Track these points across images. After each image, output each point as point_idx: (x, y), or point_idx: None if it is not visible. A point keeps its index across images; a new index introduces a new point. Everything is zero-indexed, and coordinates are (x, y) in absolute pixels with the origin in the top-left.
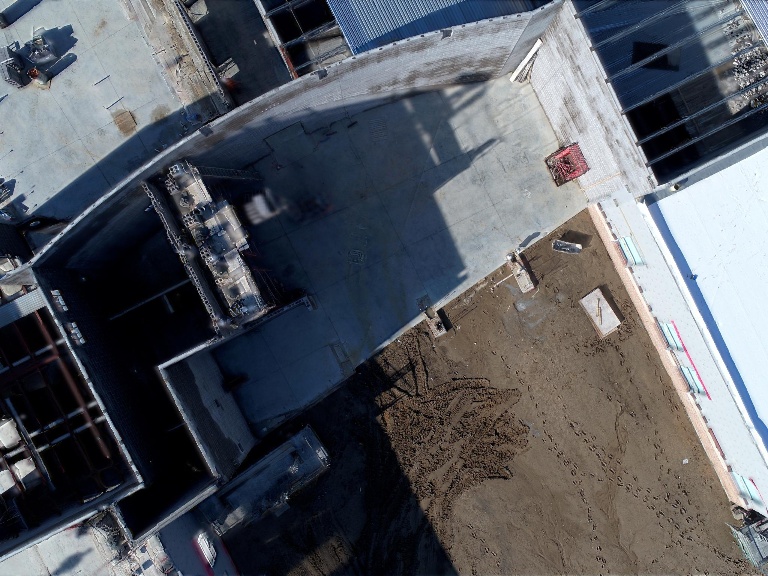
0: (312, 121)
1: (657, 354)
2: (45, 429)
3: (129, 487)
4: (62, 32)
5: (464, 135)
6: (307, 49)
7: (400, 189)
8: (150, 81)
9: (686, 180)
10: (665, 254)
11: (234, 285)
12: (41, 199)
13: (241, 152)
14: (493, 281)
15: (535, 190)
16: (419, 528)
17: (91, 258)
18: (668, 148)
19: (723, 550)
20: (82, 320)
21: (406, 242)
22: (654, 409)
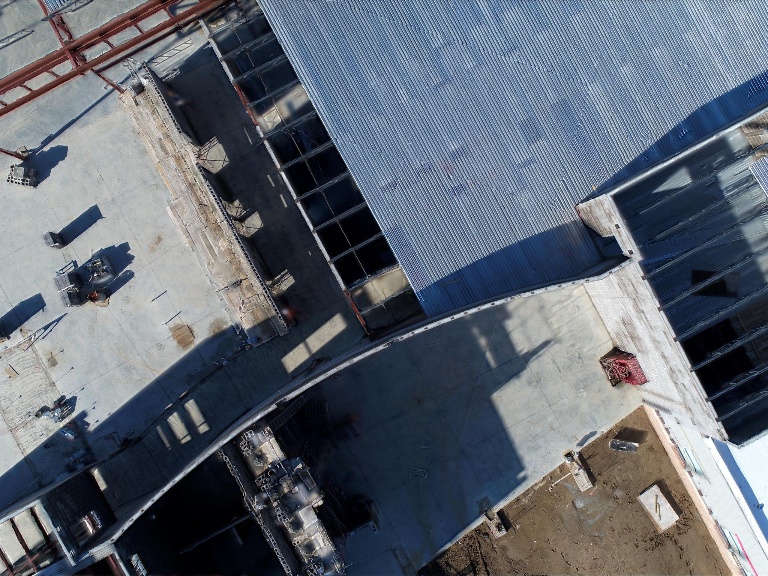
0: None
1: (716, 547)
2: None
3: None
4: (119, 250)
5: (519, 338)
6: None
7: (457, 393)
8: (207, 295)
9: None
10: (732, 486)
11: (309, 541)
12: (102, 415)
13: None
14: (551, 480)
15: (590, 390)
16: None
17: None
18: (737, 403)
19: None
20: (159, 575)
21: (464, 445)
22: None
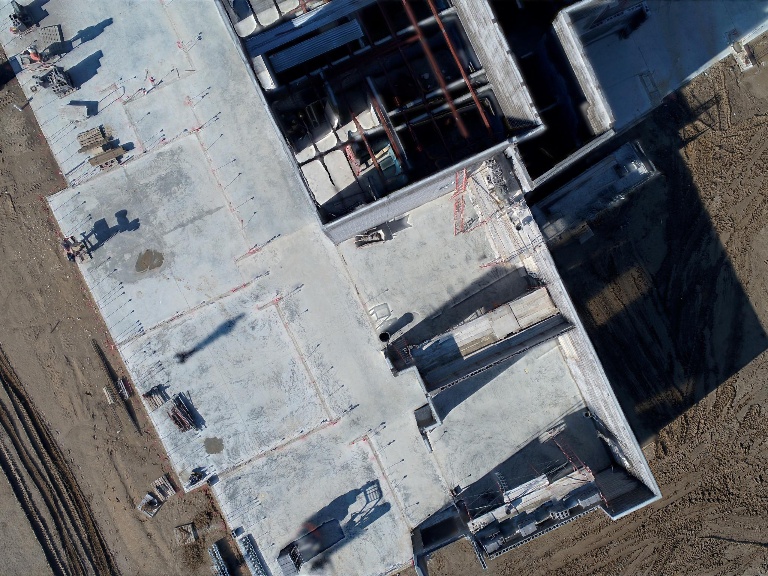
0: None
1: None
2: (403, 108)
3: None
4: None
5: None
6: None
7: None
8: None
9: None
10: None
11: None
12: None
13: None
14: None
15: None
16: (718, 261)
17: None
18: None
19: None
20: None
21: None
22: None
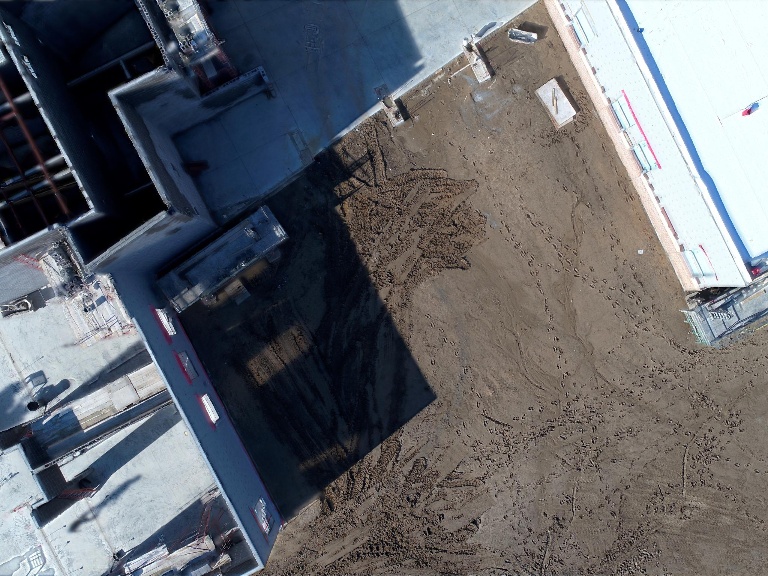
0: None
1: (612, 145)
2: (2, 185)
3: None
4: None
5: None
6: None
7: None
8: None
9: None
10: (611, 5)
11: (185, 24)
12: None
13: None
14: (450, 72)
15: None
16: (378, 317)
17: (47, 20)
18: None
19: (678, 341)
20: (36, 64)
21: (364, 31)
22: (610, 200)
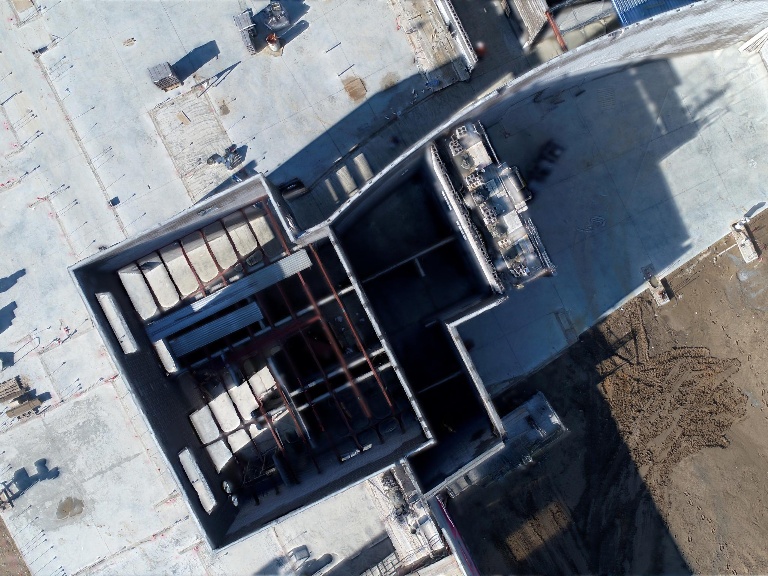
0: (553, 88)
1: None
2: (305, 388)
3: (415, 443)
4: None
5: (691, 104)
6: (560, 15)
7: (627, 158)
8: (381, 49)
9: None
10: None
11: (512, 246)
12: (272, 165)
13: (489, 118)
14: (716, 251)
15: (761, 160)
16: (637, 495)
17: (347, 221)
18: None
19: None
20: None
21: (631, 211)
22: None
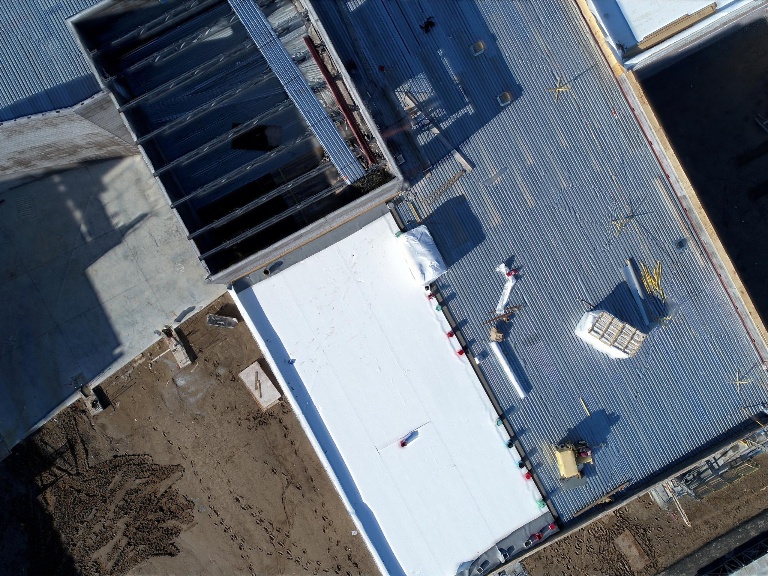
0: None
1: None
2: None
3: None
4: None
5: (115, 210)
6: None
7: (51, 267)
8: None
9: (280, 264)
10: (258, 340)
11: None
12: None
13: None
14: (151, 356)
15: (189, 264)
16: None
17: None
18: (221, 241)
19: None
20: None
21: (59, 320)
22: (320, 481)
